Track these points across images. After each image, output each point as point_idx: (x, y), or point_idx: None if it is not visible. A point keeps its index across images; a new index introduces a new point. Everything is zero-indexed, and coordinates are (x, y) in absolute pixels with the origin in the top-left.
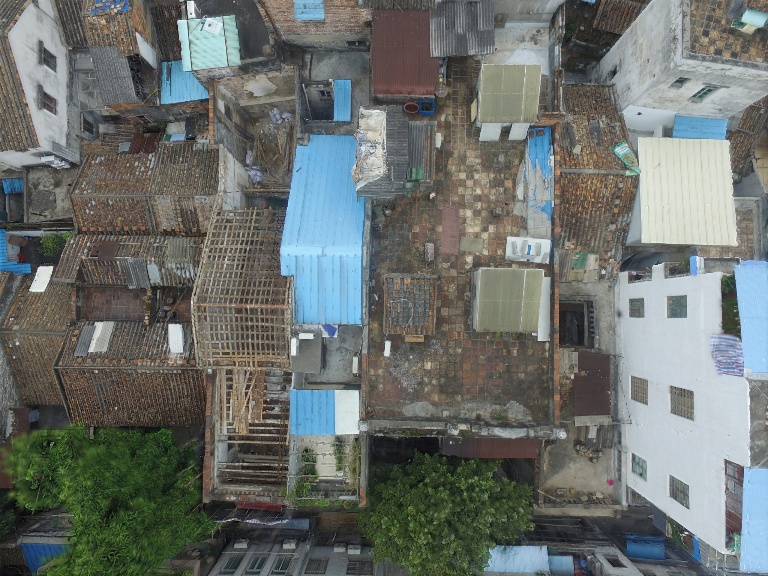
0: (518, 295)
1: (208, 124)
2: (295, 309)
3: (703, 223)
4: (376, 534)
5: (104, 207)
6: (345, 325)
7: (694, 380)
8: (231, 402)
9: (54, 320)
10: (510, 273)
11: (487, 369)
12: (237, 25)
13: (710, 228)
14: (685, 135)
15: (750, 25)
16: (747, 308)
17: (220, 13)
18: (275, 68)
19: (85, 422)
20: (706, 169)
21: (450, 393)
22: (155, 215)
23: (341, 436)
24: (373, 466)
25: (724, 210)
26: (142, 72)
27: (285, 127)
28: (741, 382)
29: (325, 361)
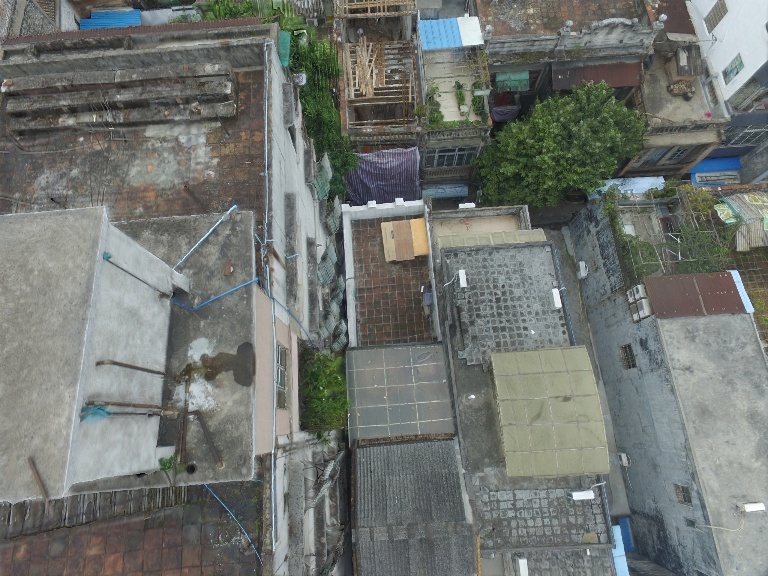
0: None
1: None
2: None
3: None
4: (503, 163)
5: None
6: None
7: None
8: (356, 73)
9: None
10: None
11: (582, 9)
12: None
13: None
14: None
15: None
16: None
17: None
18: None
19: None
20: None
21: (554, 28)
22: None
23: (468, 47)
24: None
25: None
26: None
27: None
28: None
29: None
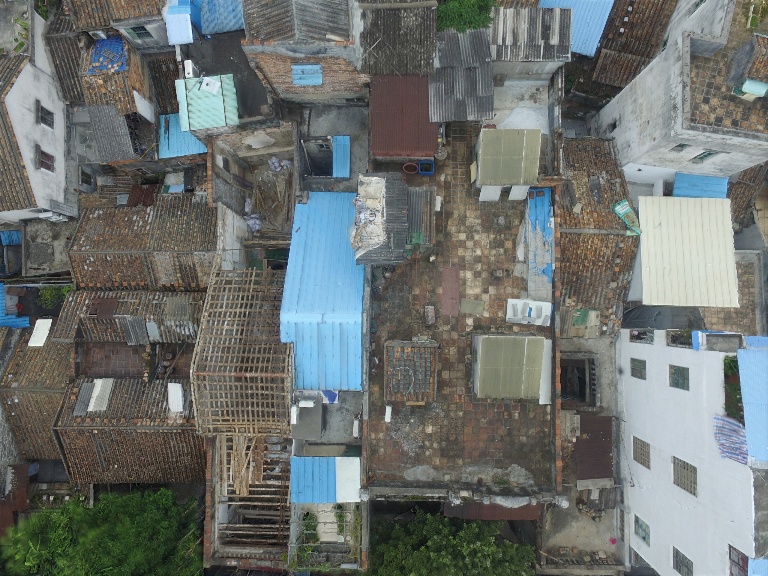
0: (519, 362)
1: (206, 175)
2: (295, 375)
3: (704, 284)
4: None
5: (102, 263)
6: None
7: (697, 456)
8: (231, 463)
9: (53, 377)
10: (511, 341)
11: (488, 432)
12: (235, 82)
13: (712, 289)
14: (686, 193)
15: (751, 94)
16: (750, 394)
17: (218, 70)
18: (273, 125)
19: (85, 479)
20: (707, 228)
21: (451, 457)
22: (154, 270)
23: (342, 504)
24: (374, 523)
25: (725, 270)
26: (140, 129)
27: (284, 174)
28: (745, 470)
29: (325, 422)
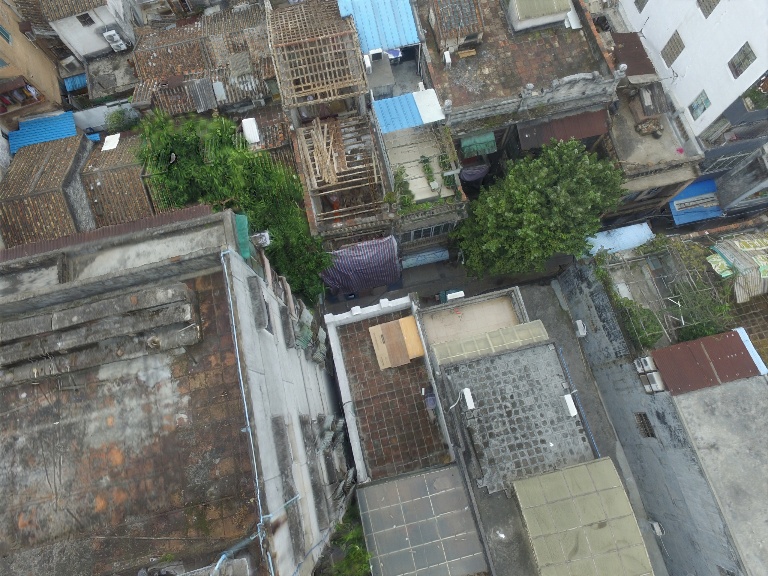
0: None
1: None
2: (359, 42)
3: None
4: (484, 236)
5: (164, 57)
6: (406, 47)
7: None
8: (315, 160)
9: (131, 158)
10: None
11: (538, 62)
12: None
13: None
14: None
15: None
16: None
17: None
18: None
19: None
20: None
21: (513, 87)
22: (210, 56)
23: (429, 125)
24: None
25: None
26: None
27: None
28: None
29: None
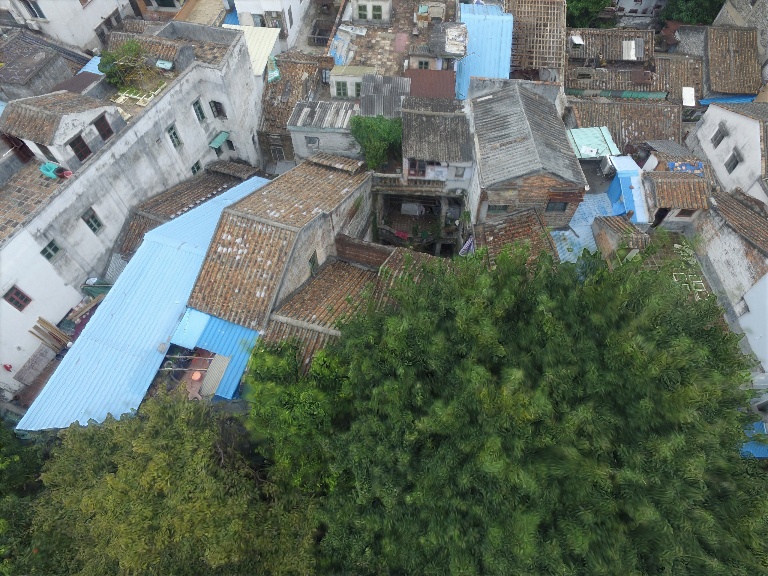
0: None
1: None
2: None
3: None
4: None
5: None
6: None
7: None
8: None
9: None
10: None
11: None
12: None
13: None
14: None
15: None
16: None
17: (586, 176)
18: None
19: None
20: None
21: None
22: None
23: None
24: None
25: None
26: None
27: None
28: None
29: None
